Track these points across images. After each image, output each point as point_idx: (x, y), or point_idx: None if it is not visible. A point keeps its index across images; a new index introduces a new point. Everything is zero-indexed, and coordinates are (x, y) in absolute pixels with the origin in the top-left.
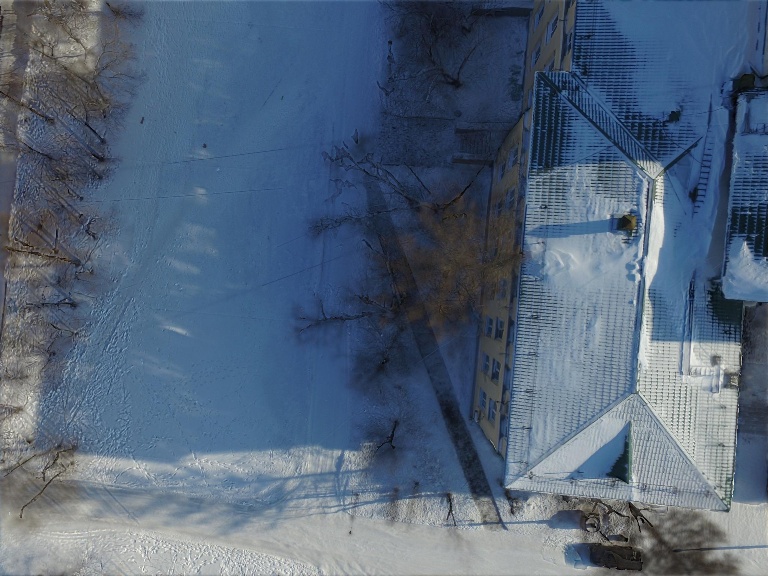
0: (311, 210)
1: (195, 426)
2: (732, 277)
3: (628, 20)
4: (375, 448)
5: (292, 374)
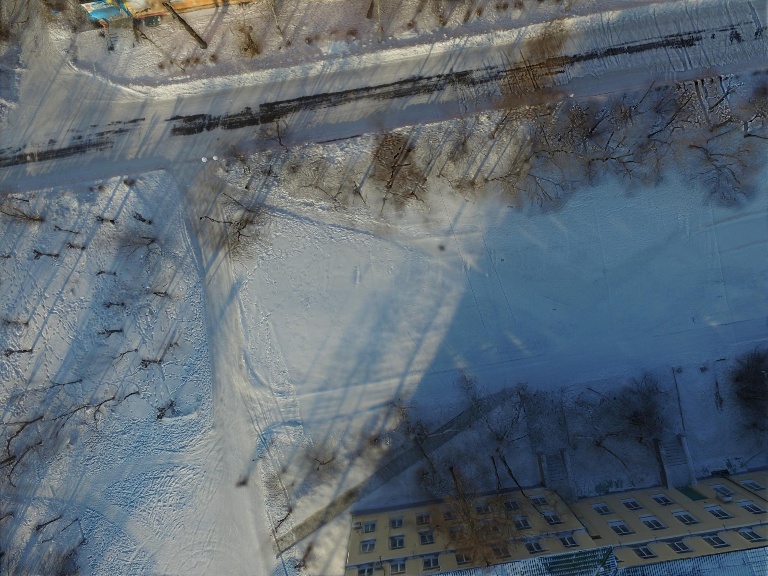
0: (474, 354)
1: (291, 310)
2: None
3: None
4: (310, 447)
5: (348, 371)
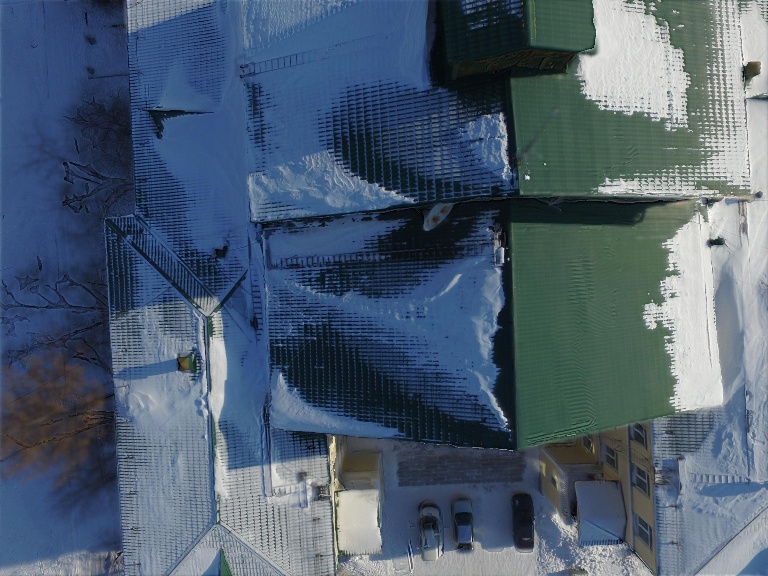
0: (45, 324)
1: None
2: (272, 409)
3: (175, 161)
4: None
5: (50, 485)
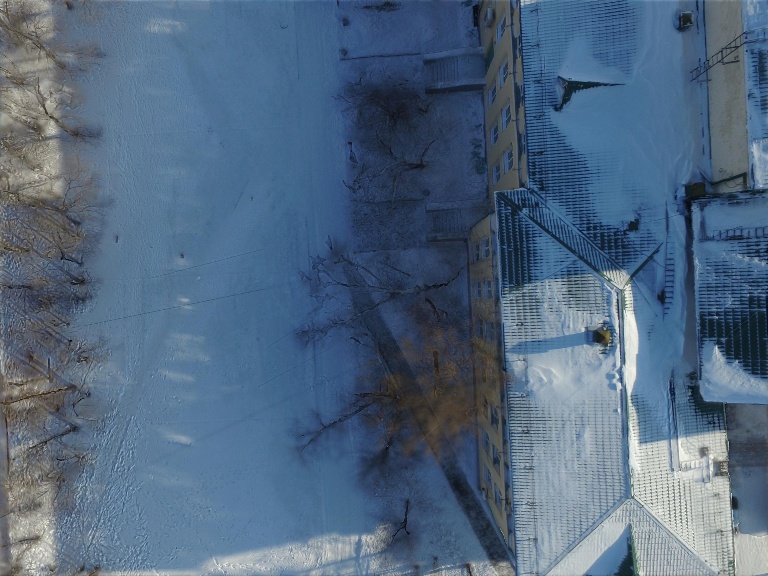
0: (296, 306)
1: (212, 533)
2: (708, 381)
3: (577, 134)
4: (391, 529)
5: (300, 469)
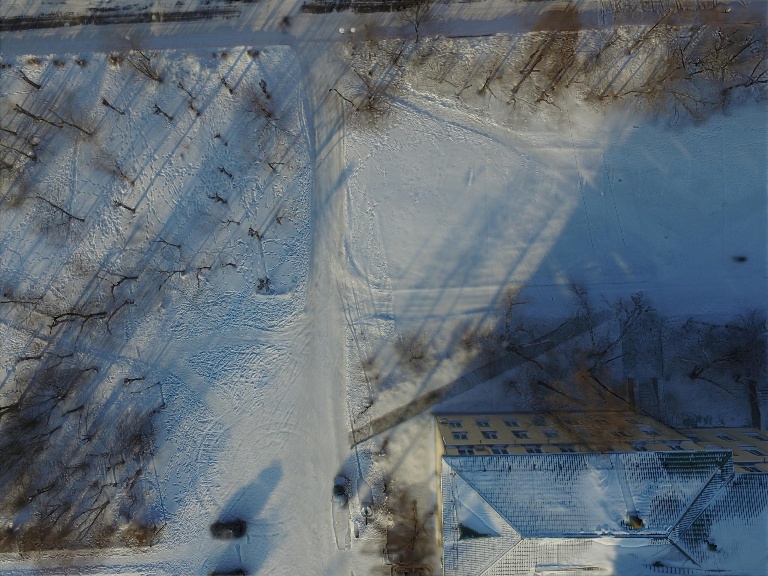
0: (578, 272)
1: (399, 203)
2: None
3: None
4: (399, 343)
5: (447, 273)
